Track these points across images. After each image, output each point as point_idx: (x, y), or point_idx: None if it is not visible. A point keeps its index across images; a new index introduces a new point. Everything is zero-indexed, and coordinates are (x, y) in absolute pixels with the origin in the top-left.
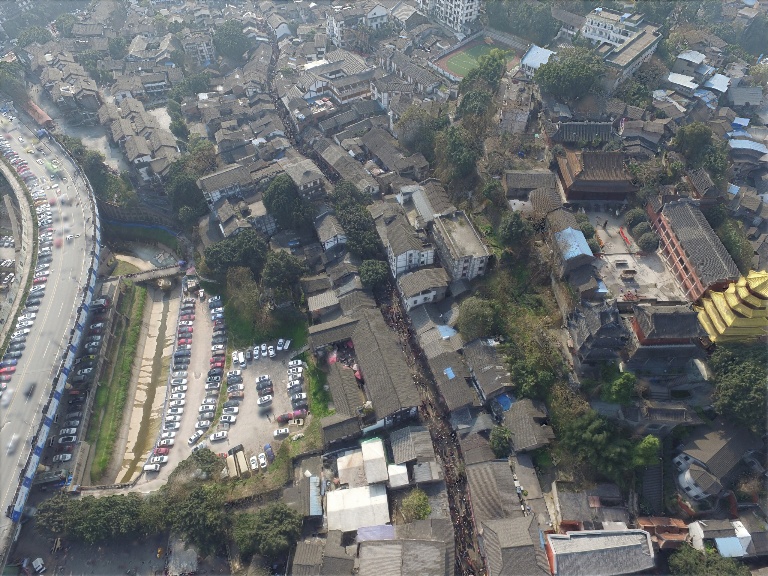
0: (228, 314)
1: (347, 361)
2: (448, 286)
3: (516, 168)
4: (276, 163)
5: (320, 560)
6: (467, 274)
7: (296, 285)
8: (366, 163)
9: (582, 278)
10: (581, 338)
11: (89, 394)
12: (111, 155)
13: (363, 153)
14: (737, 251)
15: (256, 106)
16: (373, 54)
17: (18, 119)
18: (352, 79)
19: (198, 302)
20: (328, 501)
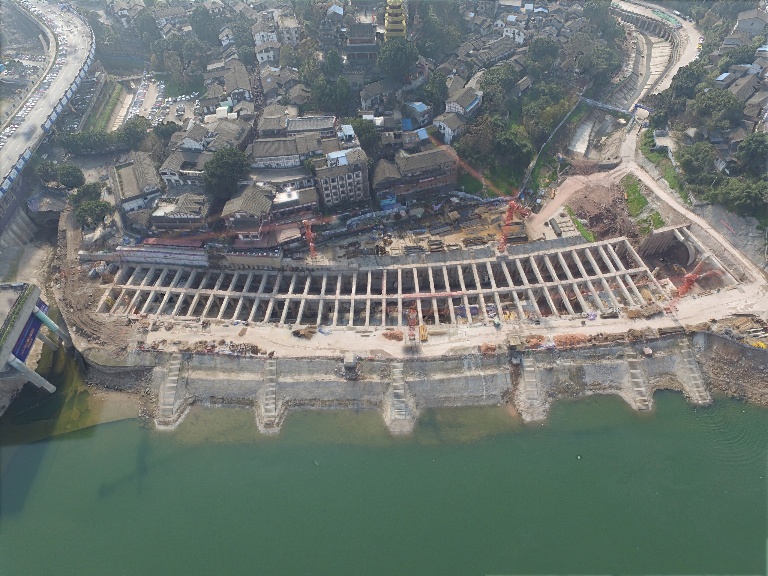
0: (167, 88)
1: None
2: None
3: None
4: None
5: None
6: (292, 44)
7: (206, 68)
8: None
9: None
10: None
11: (85, 114)
12: (106, 18)
13: (259, 6)
14: (434, 24)
15: None
16: None
17: (48, 2)
18: None
19: (151, 84)
20: None
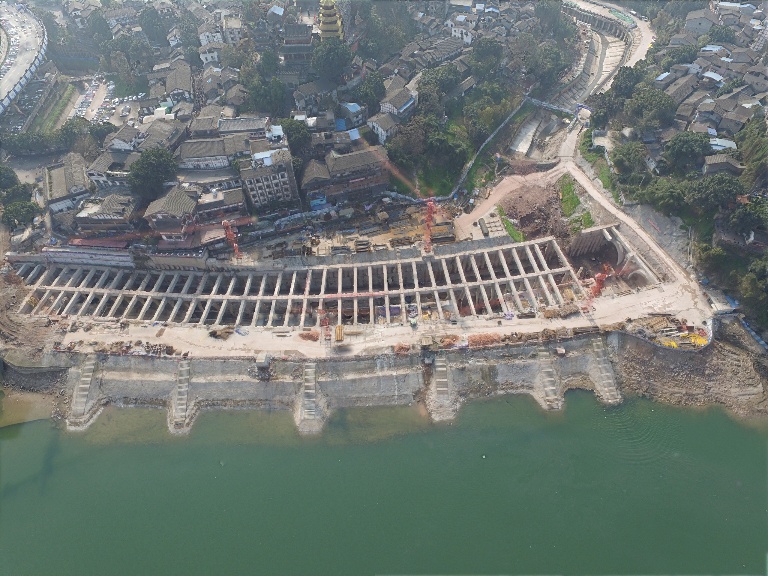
0: (117, 88)
1: None
2: None
3: None
4: None
5: None
6: (236, 45)
7: None
8: None
9: None
10: None
11: (30, 114)
12: (63, 19)
13: (212, 6)
14: (376, 24)
15: None
16: None
17: (6, 2)
18: None
19: (101, 85)
20: None
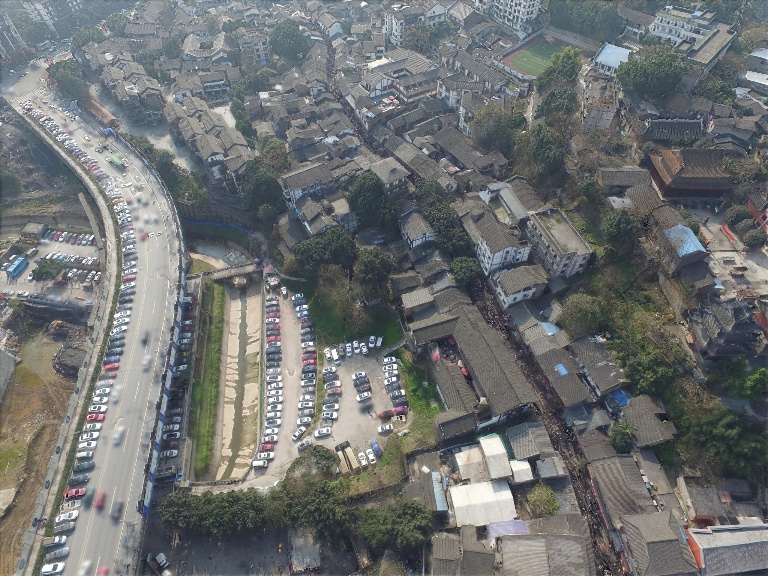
0: (313, 311)
1: (449, 358)
2: (547, 283)
3: (605, 165)
4: (353, 161)
5: (459, 554)
6: (565, 271)
7: (383, 282)
8: (439, 161)
9: (697, 274)
10: (710, 334)
11: (187, 391)
12: (178, 154)
13: (437, 151)
14: None
15: (323, 105)
16: (432, 53)
17: (81, 118)
18: (418, 77)
19: (281, 300)
20: (453, 496)
